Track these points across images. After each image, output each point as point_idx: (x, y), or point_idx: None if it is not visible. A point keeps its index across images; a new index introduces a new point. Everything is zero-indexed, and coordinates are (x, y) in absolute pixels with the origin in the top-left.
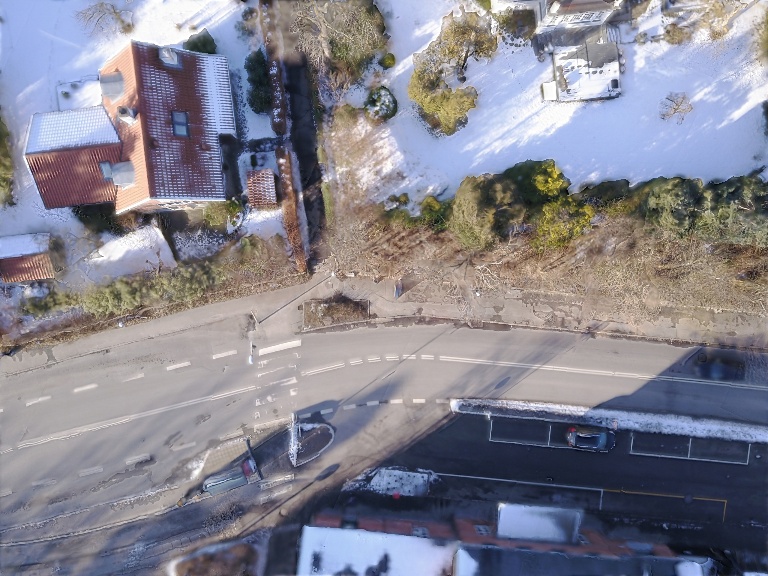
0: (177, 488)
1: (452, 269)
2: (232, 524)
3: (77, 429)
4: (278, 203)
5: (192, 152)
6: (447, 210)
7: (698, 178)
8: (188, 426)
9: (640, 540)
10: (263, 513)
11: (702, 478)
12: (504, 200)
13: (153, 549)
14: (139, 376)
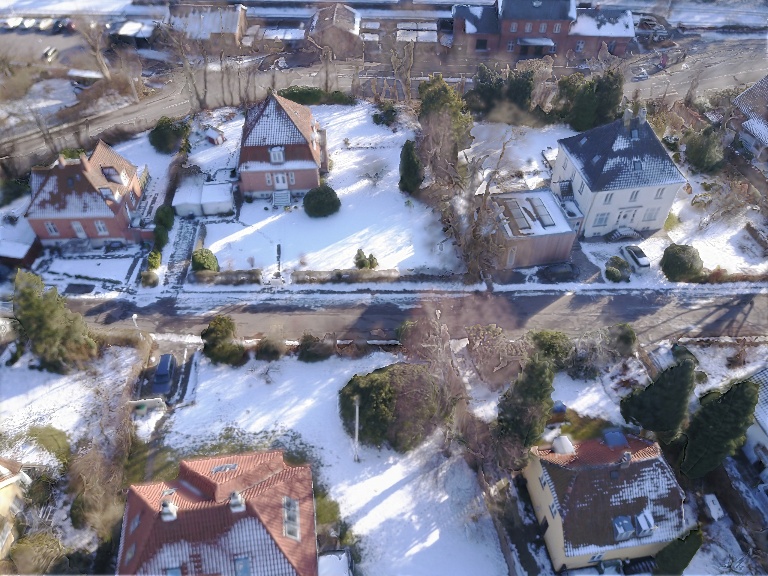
0: (690, 61)
1: (619, 64)
2: (659, 54)
3: (746, 72)
4: (702, 116)
5: (759, 103)
6: (619, 106)
7: (523, 78)
8: (697, 74)
9: (478, 54)
10: (647, 57)
11: (453, 70)
12: (608, 74)
13: (689, 49)
14: (729, 86)
